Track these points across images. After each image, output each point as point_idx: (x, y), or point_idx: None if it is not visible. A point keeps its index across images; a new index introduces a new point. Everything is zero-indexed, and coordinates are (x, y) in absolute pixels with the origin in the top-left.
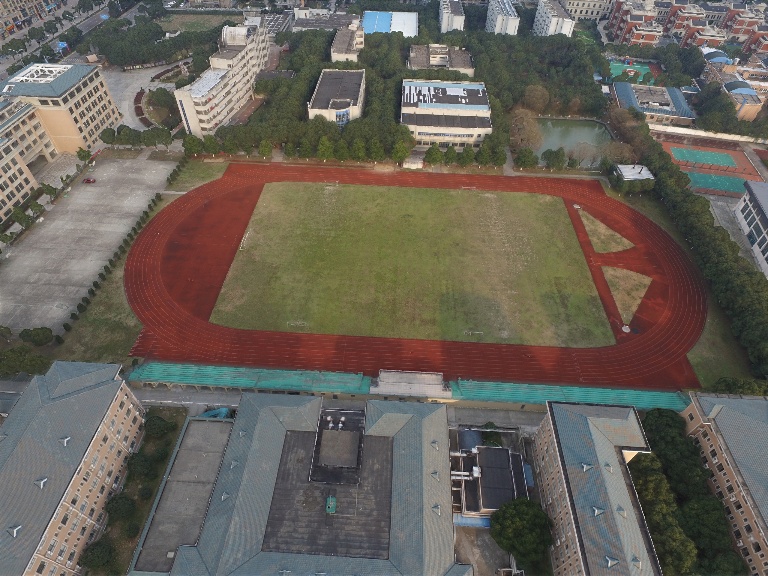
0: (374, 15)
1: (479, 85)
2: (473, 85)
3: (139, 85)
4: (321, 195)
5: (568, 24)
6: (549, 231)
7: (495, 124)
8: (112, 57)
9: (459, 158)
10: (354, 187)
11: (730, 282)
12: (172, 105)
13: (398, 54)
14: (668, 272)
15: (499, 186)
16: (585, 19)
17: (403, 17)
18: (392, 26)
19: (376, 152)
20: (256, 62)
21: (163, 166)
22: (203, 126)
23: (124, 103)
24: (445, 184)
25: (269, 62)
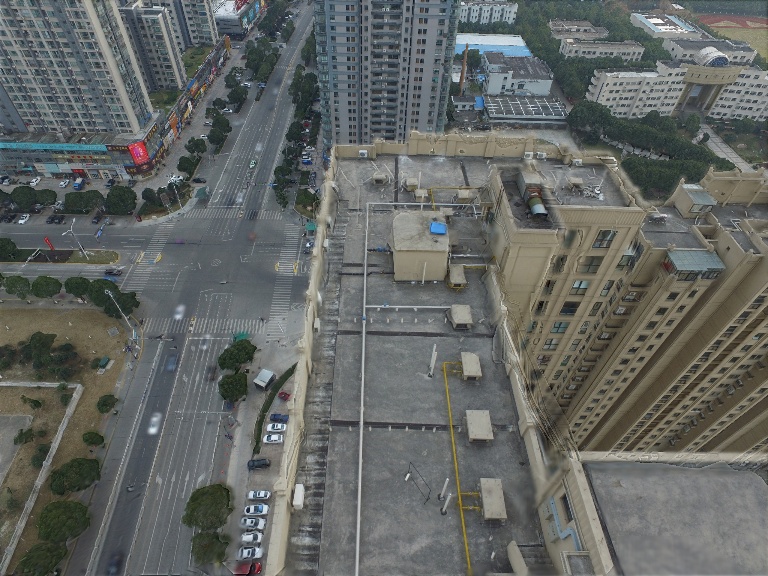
0: None
1: (635, 15)
2: None
3: None
4: None
5: None
6: (739, 32)
7: None
8: None
9: None
10: None
11: (756, 2)
12: (762, 142)
13: None
14: (738, 18)
15: None
16: None
17: (464, 39)
18: (495, 44)
19: None
20: None
21: None
22: None
23: None
24: None
25: None
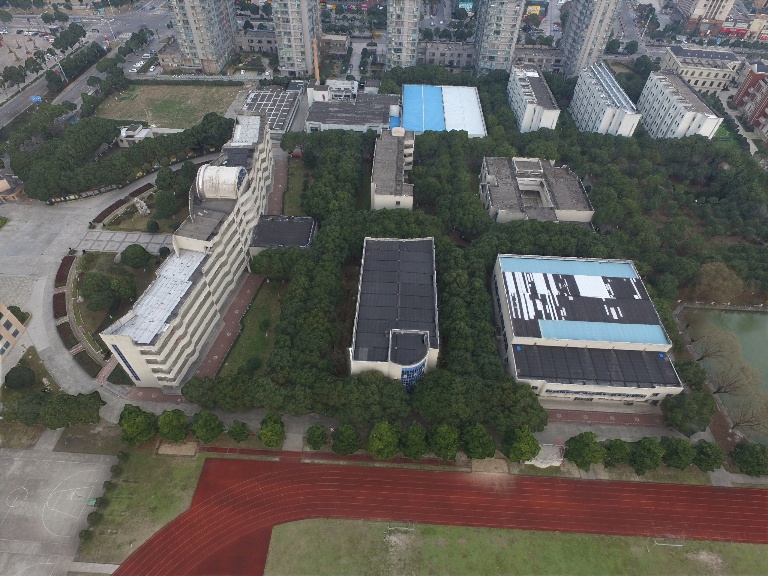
0: (417, 92)
1: (625, 266)
2: (615, 266)
3: (69, 237)
4: (384, 569)
5: (711, 122)
6: None
7: (685, 375)
8: (29, 189)
9: (633, 459)
10: (444, 536)
11: None
12: None
13: (467, 175)
14: None
15: (716, 524)
16: (700, 92)
17: (458, 96)
18: (446, 113)
19: (480, 452)
20: (253, 214)
21: (81, 472)
22: (159, 376)
23: (38, 283)
24: (613, 519)
25: (272, 181)
